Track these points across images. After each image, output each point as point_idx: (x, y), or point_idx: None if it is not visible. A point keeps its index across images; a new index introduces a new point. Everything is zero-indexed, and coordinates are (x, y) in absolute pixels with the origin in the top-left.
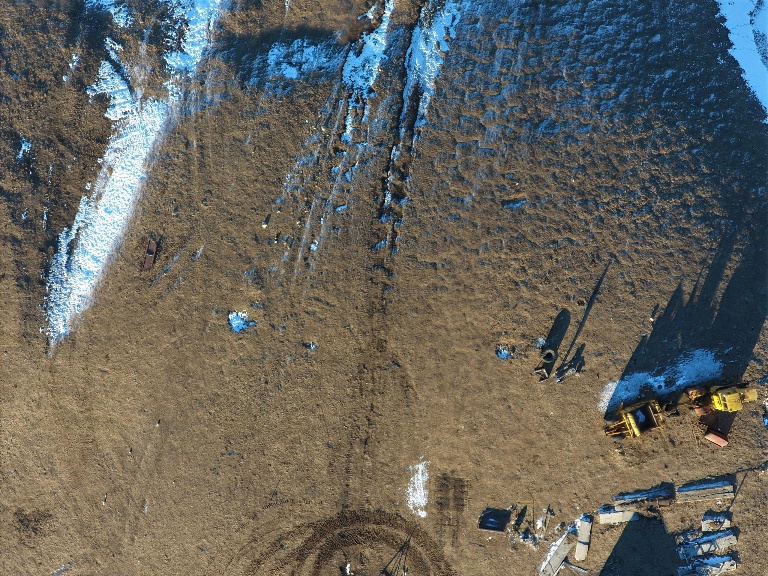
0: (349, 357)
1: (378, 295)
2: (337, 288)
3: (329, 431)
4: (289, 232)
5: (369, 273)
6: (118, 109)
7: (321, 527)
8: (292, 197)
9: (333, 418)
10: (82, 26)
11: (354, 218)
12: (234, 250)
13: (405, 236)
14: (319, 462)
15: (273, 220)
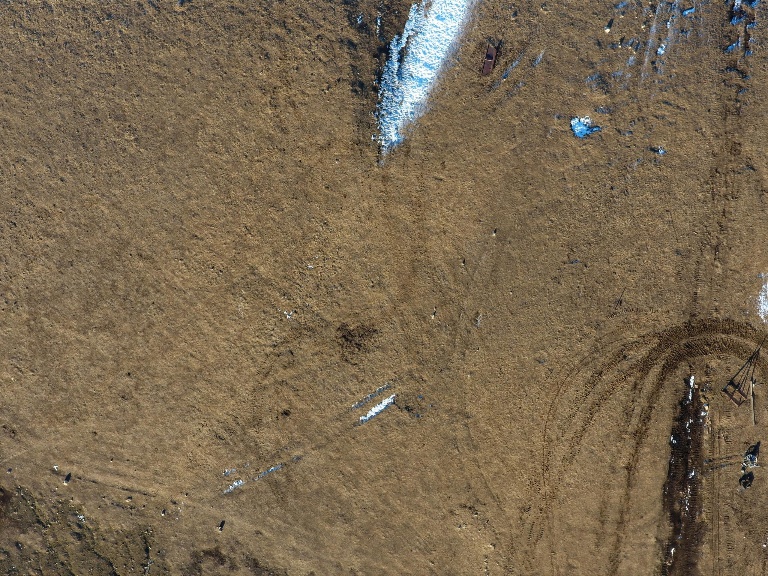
0: (701, 161)
1: (732, 97)
2: (688, 91)
3: (678, 237)
4: (633, 37)
5: (722, 75)
6: None
7: (667, 337)
8: (635, 2)
9: (682, 224)
10: None
11: (703, 21)
12: (576, 55)
13: (759, 38)
14: (667, 269)
15: (616, 25)
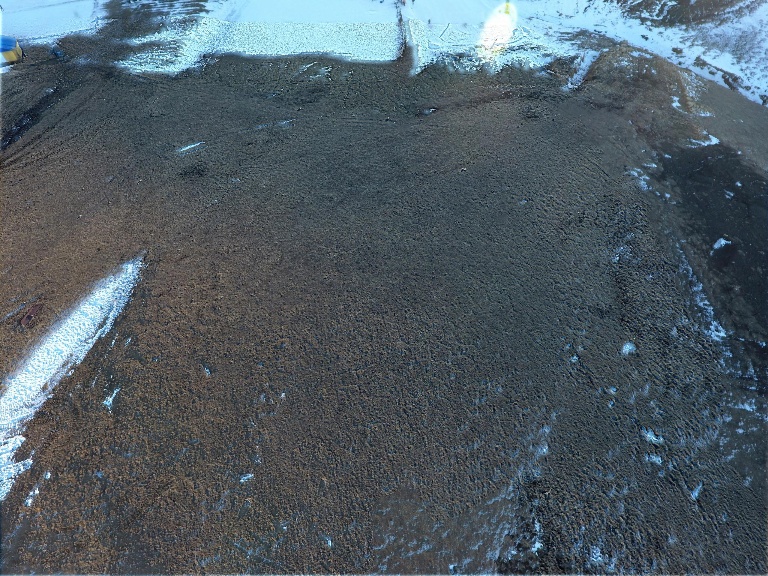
0: None
1: None
2: None
3: None
4: None
5: None
6: (10, 447)
7: None
8: None
9: None
10: (8, 544)
11: None
12: None
13: None
14: None
15: None
